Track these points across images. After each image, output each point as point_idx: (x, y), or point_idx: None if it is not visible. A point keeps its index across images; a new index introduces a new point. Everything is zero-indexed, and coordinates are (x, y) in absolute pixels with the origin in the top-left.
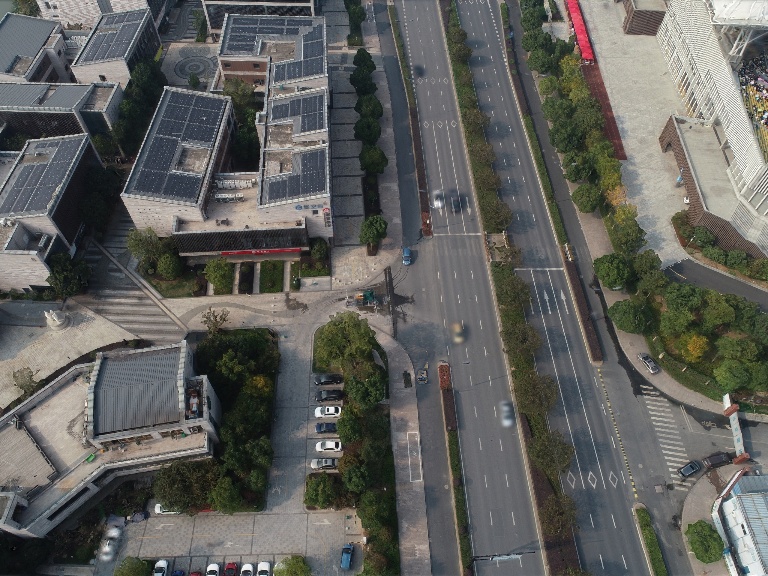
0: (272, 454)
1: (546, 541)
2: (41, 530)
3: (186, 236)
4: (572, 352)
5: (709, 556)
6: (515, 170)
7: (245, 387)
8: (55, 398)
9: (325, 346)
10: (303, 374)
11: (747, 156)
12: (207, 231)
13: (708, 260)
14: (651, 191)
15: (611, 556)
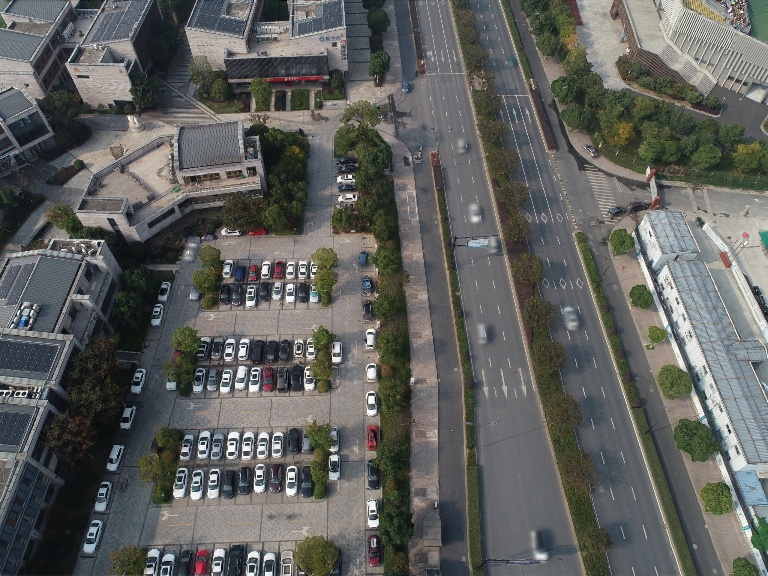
0: (307, 194)
1: (508, 249)
2: (143, 234)
3: (235, 61)
4: (533, 145)
5: (623, 247)
6: (493, 33)
7: (286, 152)
8: (145, 157)
9: (345, 124)
10: (327, 158)
11: (672, 6)
12: (251, 57)
13: (642, 88)
14: (601, 45)
15: (555, 259)
